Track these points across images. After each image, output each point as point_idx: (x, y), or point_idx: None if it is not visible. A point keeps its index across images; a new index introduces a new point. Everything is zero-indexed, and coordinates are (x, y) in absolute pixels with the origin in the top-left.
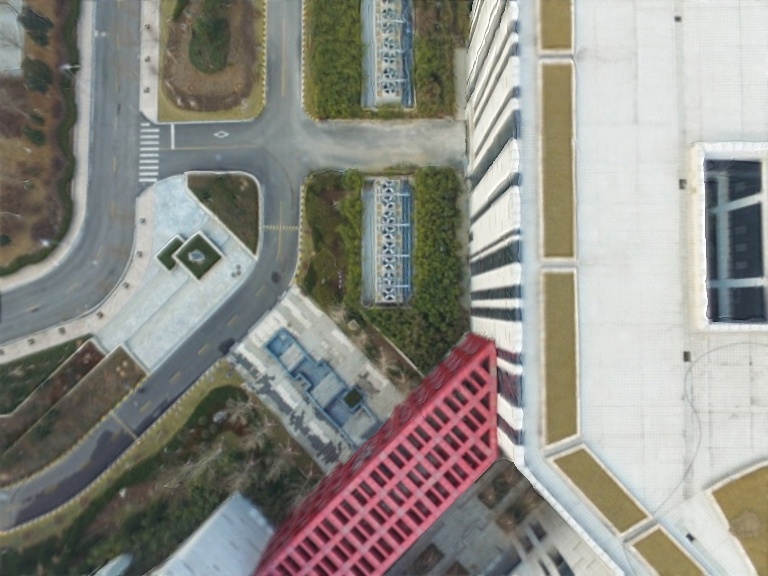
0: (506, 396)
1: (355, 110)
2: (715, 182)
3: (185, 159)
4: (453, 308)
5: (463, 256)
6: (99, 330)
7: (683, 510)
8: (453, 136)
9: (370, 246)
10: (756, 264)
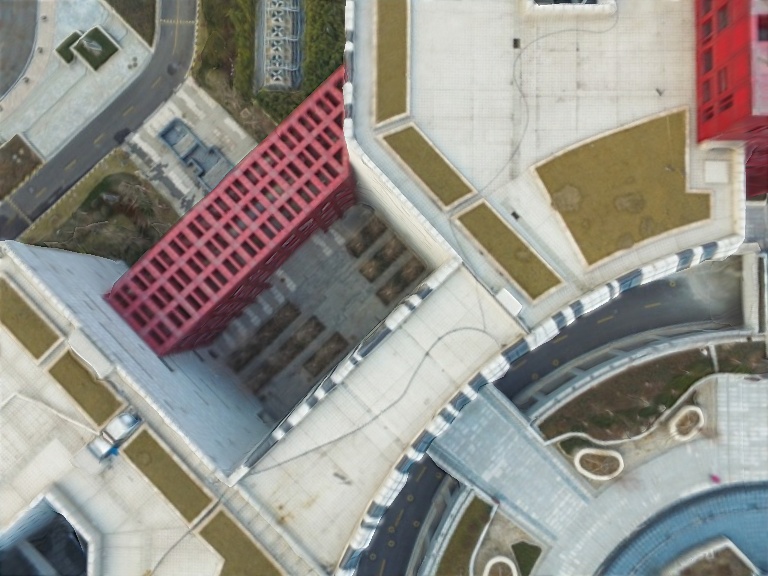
0: None
1: None
2: None
3: None
4: None
5: None
6: None
7: (509, 189)
8: None
9: (262, 35)
10: None
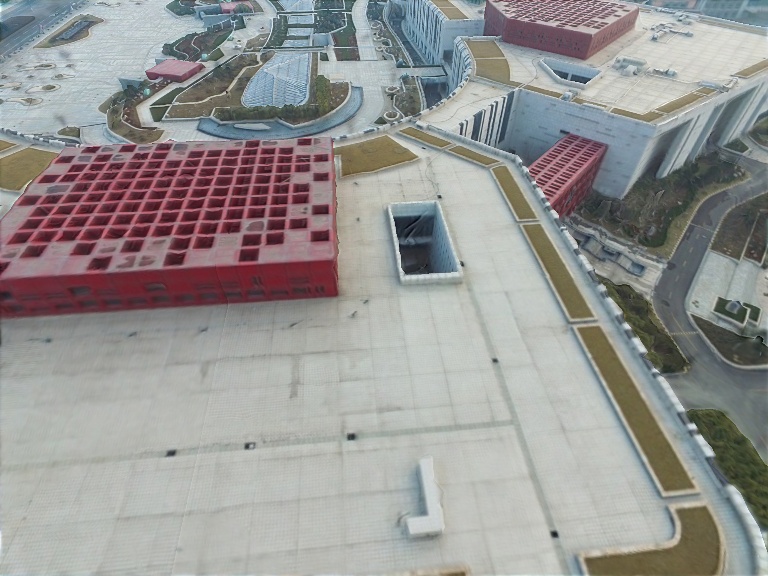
0: None
1: None
2: None
3: None
4: None
5: None
6: (760, 271)
7: (429, 154)
8: None
9: None
10: None
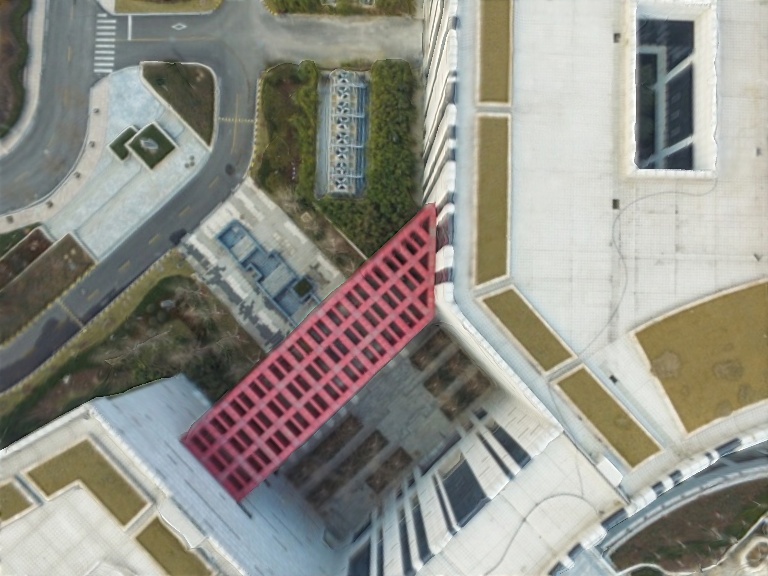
0: (441, 245)
1: (313, 2)
2: (654, 55)
3: (141, 50)
4: (404, 199)
5: (417, 153)
6: (48, 219)
7: (608, 352)
8: (411, 35)
9: (325, 139)
10: (686, 123)
